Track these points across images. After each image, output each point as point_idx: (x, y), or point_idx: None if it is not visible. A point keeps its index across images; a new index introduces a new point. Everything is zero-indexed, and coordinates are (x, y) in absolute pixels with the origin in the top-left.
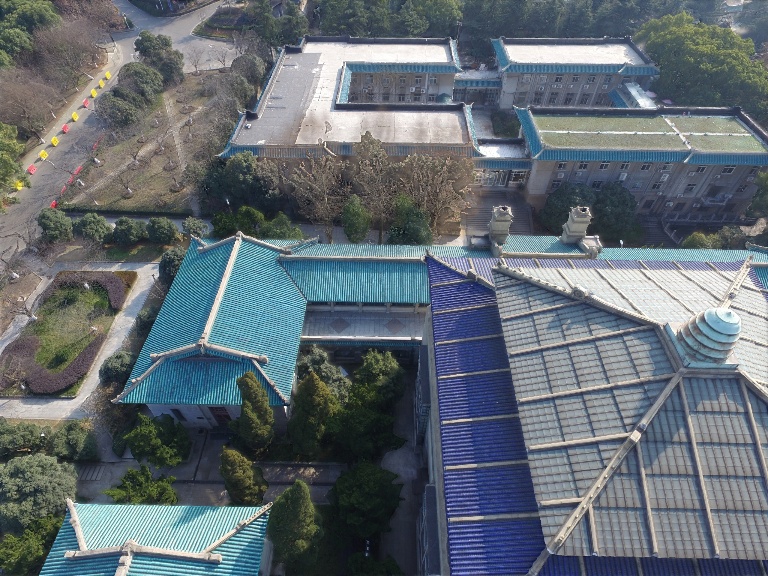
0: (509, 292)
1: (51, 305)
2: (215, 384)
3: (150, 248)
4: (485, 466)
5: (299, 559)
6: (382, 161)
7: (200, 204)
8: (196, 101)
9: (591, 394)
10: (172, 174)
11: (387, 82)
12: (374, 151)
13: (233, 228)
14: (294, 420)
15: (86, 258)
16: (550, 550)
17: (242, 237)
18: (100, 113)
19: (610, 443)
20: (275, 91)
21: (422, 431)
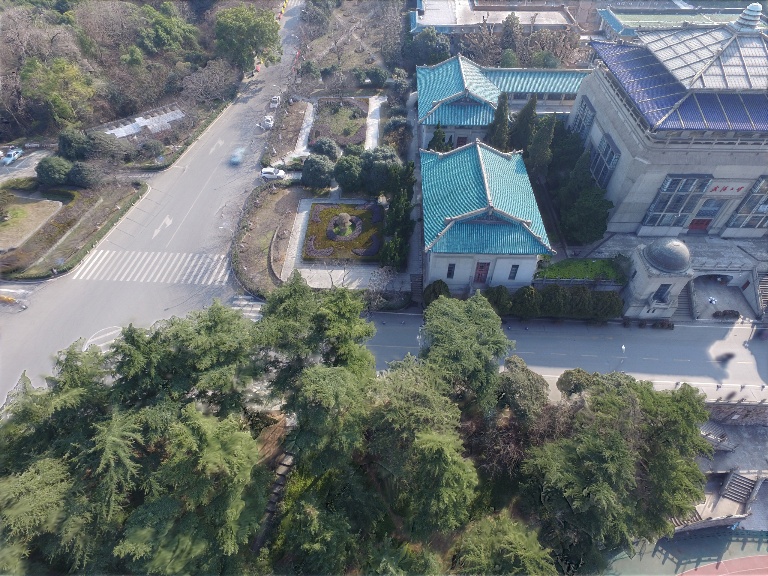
0: (647, 36)
1: (324, 113)
2: (471, 115)
3: (368, 90)
4: (648, 88)
5: (542, 169)
6: (521, 32)
7: (390, 69)
8: (357, 16)
9: (697, 50)
10: (362, 54)
11: (497, 1)
12: (517, 24)
13: (445, 59)
14: (519, 128)
15: (330, 94)
16: (688, 86)
17: (461, 56)
18: (309, 14)
19: (708, 59)
20: (427, 1)
21: (582, 143)
